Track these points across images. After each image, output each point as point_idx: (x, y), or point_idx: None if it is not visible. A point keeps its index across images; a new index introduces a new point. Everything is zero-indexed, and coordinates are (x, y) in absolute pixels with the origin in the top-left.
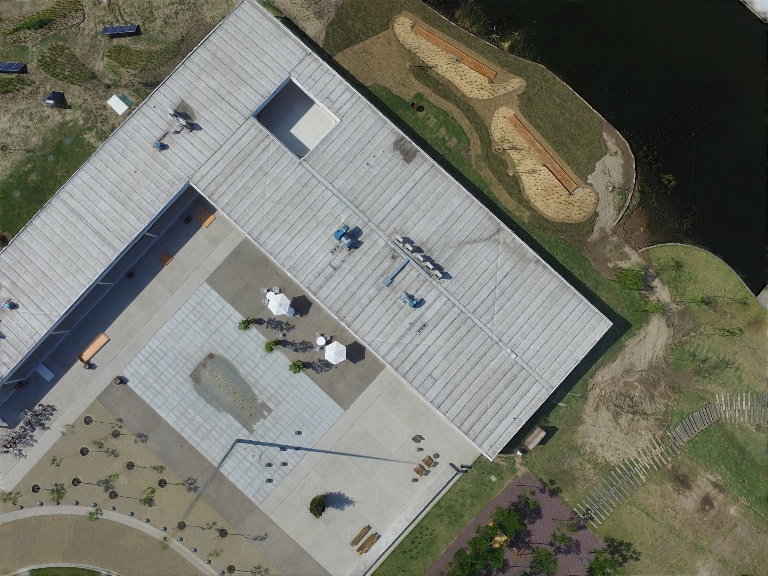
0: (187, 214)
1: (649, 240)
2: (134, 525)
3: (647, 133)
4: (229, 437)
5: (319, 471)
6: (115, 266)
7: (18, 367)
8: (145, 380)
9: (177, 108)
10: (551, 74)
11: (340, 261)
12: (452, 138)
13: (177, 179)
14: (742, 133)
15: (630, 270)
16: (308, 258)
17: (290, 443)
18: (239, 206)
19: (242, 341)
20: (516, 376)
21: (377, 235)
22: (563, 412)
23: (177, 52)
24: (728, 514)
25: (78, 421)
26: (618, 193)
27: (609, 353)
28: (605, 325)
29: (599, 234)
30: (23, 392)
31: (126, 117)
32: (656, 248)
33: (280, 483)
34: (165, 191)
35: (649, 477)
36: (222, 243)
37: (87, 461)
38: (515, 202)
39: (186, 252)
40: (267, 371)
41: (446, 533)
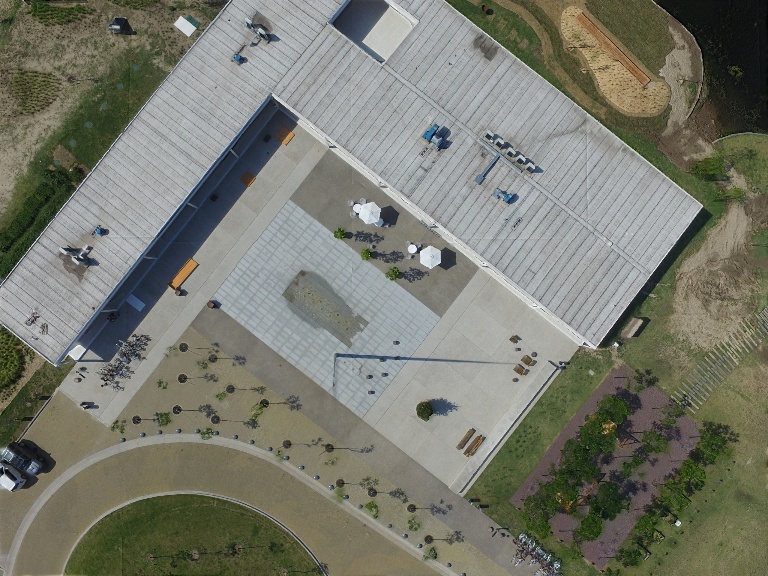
0: (266, 133)
1: (721, 132)
2: (239, 448)
3: (711, 26)
4: (327, 352)
5: (420, 379)
6: (203, 185)
7: (114, 294)
8: (238, 303)
9: (252, 20)
10: None
11: (431, 162)
12: (524, 39)
13: (259, 92)
14: None
15: None
16: (398, 162)
17: (389, 354)
18: (324, 114)
19: (332, 256)
20: (613, 264)
21: (465, 134)
22: (654, 303)
23: None
24: None
25: None
26: (689, 86)
27: (693, 242)
28: (696, 207)
29: (673, 128)
30: (115, 324)
31: (195, 38)
32: (729, 138)
33: (382, 394)
34: (248, 105)
35: (741, 360)
36: (303, 159)
37: (186, 388)
38: (591, 99)
39: (268, 171)
40: (360, 284)
41: (549, 430)
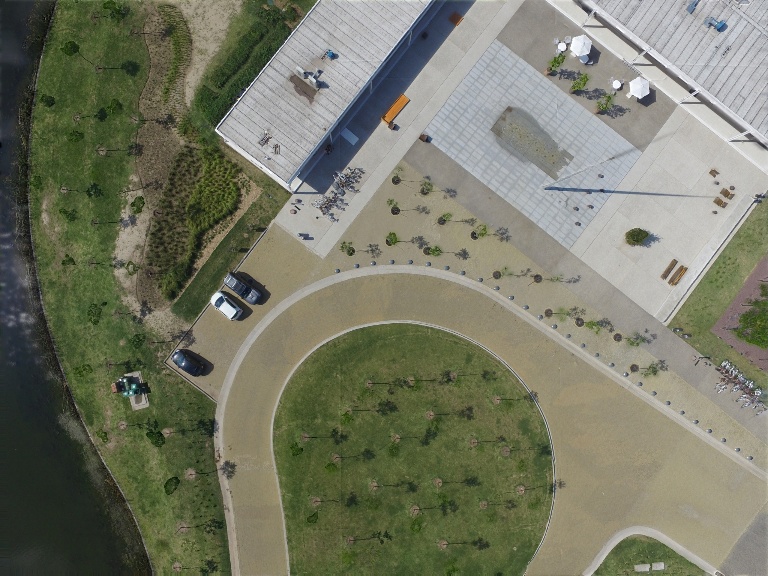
0: None
1: None
2: (451, 278)
3: None
4: (535, 185)
5: (623, 211)
6: None
7: (343, 116)
8: (448, 137)
9: None
10: None
11: None
12: None
13: None
14: None
15: None
16: None
17: (594, 187)
18: None
19: (538, 93)
20: None
21: None
22: None
23: None
24: None
25: (387, 182)
26: None
27: None
28: None
29: None
30: (329, 158)
31: None
32: None
33: (588, 226)
34: None
35: None
36: (509, 1)
37: (399, 220)
38: None
39: (475, 11)
40: (565, 120)
41: (746, 261)
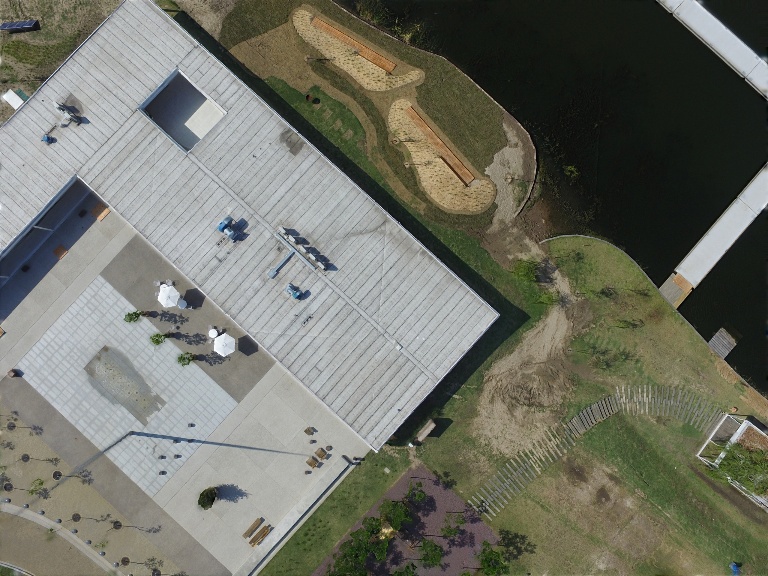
0: (82, 207)
1: (551, 232)
2: (29, 517)
3: (550, 124)
4: (123, 429)
5: (212, 463)
6: (4, 259)
7: None
8: (40, 373)
9: (65, 102)
10: (452, 66)
11: (226, 253)
12: (348, 130)
13: (64, 172)
14: (646, 124)
15: (530, 262)
16: (194, 250)
17: (183, 435)
18: (125, 199)
19: (136, 334)
20: (401, 367)
21: (263, 227)
22: (458, 404)
23: (73, 46)
24: (624, 506)
25: None
26: (518, 185)
27: (505, 345)
28: (491, 316)
29: (499, 226)
30: None
31: None
32: (557, 240)
33: (174, 475)
34: (52, 184)
35: (544, 469)
36: (117, 236)
37: None
38: (411, 194)
39: (81, 245)
40: (161, 364)
41: (339, 525)
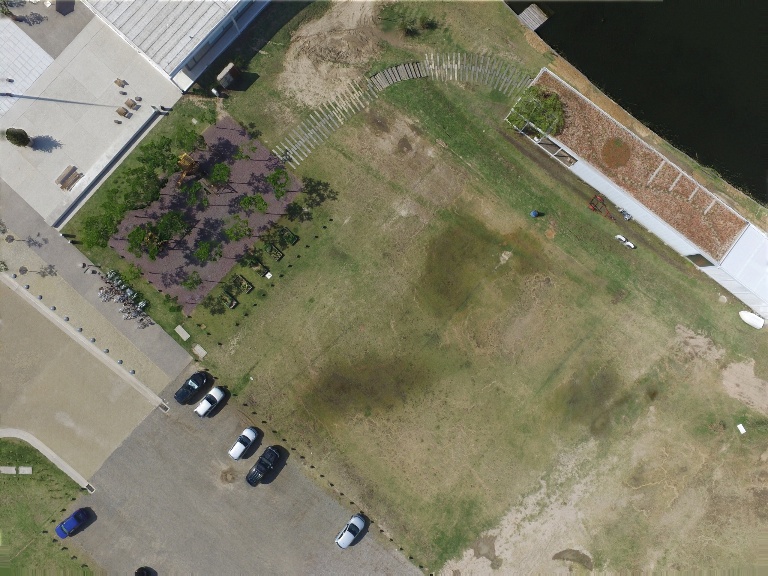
0: None
1: None
2: None
3: None
4: None
5: (29, 116)
6: None
7: None
8: None
9: None
10: None
11: None
12: None
13: None
14: None
15: None
16: None
17: (3, 90)
18: None
19: None
20: None
21: None
22: (264, 60)
23: None
24: (426, 156)
25: None
26: None
27: (313, 8)
28: None
29: None
30: None
31: None
32: None
33: None
34: None
35: (347, 120)
36: None
37: None
38: None
39: None
40: None
41: None
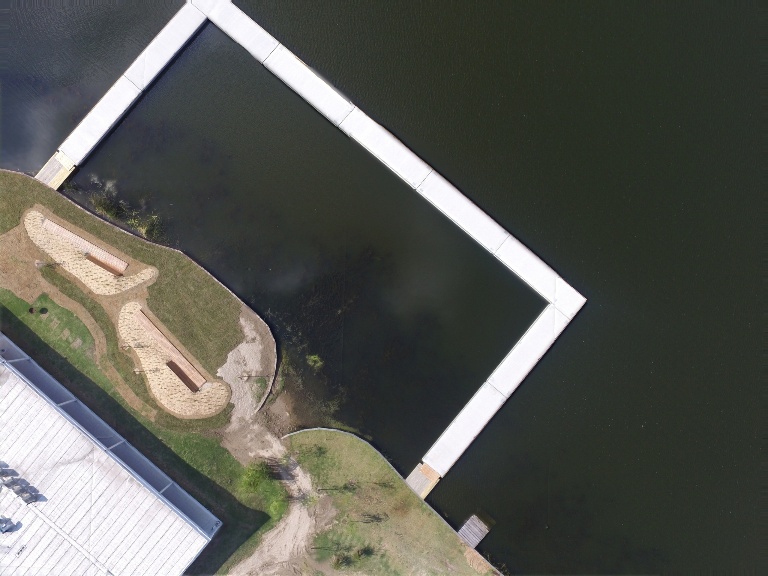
0: None
1: (295, 424)
2: None
3: (292, 313)
4: None
5: None
6: None
7: None
8: None
9: None
10: (187, 260)
11: None
12: (76, 339)
13: None
14: (392, 307)
15: (271, 459)
16: None
17: None
18: None
19: None
20: None
21: None
22: None
23: None
24: None
25: None
26: (255, 381)
27: (242, 549)
28: (201, 542)
29: (239, 423)
30: None
31: None
32: (299, 434)
33: None
34: None
35: None
36: None
37: None
38: (141, 401)
39: None
40: None
41: None
